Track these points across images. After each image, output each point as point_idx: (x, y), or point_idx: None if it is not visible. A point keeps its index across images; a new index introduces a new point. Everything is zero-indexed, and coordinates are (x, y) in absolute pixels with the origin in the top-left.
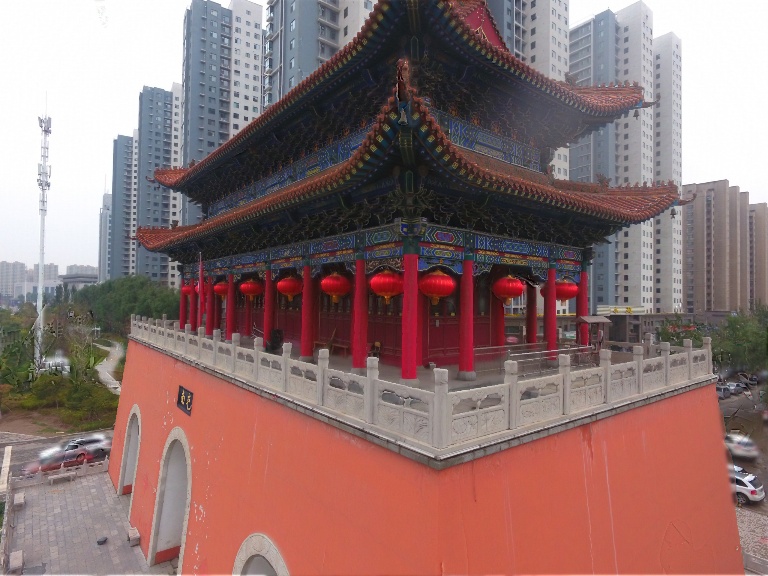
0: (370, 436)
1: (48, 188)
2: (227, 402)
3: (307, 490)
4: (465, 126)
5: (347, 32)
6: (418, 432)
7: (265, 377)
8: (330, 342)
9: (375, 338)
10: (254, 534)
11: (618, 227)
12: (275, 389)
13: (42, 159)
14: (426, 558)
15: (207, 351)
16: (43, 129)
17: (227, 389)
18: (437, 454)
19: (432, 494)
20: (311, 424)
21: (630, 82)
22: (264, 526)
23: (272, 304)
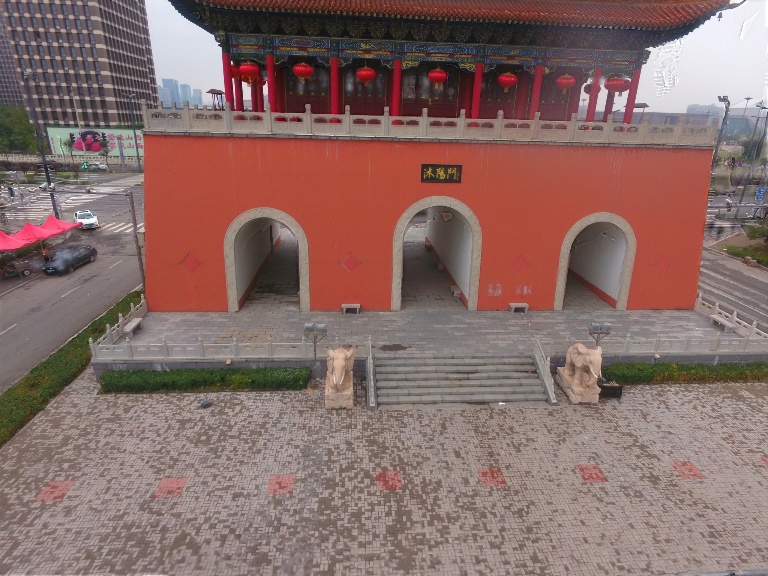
0: None
1: None
2: None
3: None
4: None
5: None
6: None
7: None
8: None
9: None
10: None
11: (197, 7)
12: None
13: None
14: None
15: None
16: None
17: None
18: None
19: None
20: None
21: None
22: None
23: None
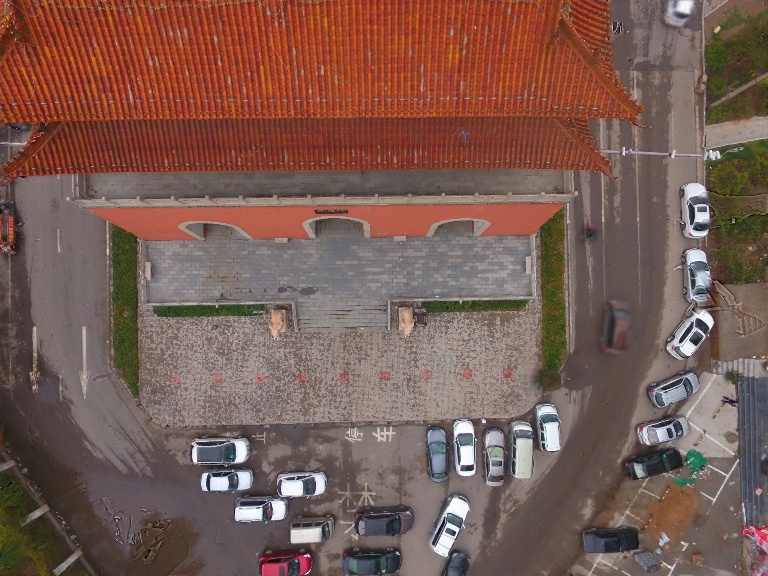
0: None
1: None
2: None
3: None
4: None
5: None
6: None
7: None
8: None
9: None
10: None
11: None
12: None
13: None
14: None
15: None
16: None
17: None
18: None
19: None
20: None
21: None
22: None
23: None
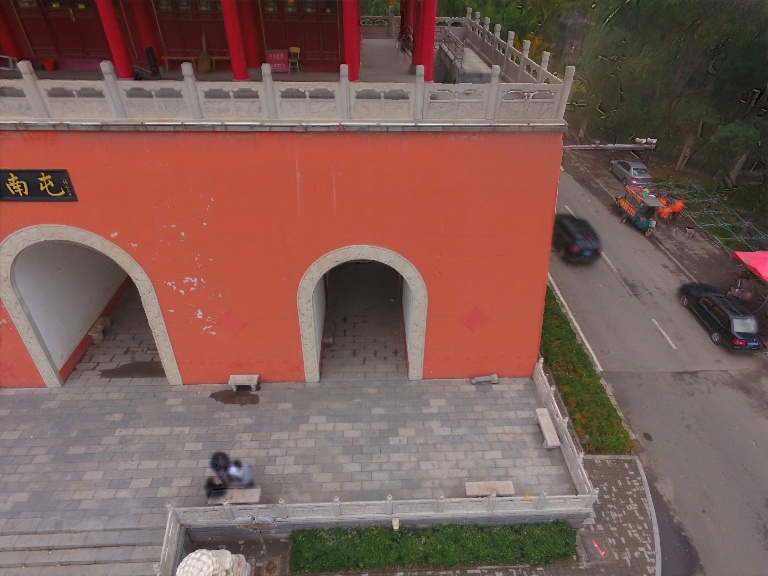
0: (500, 128)
1: None
2: (206, 157)
3: (413, 190)
4: None
5: None
6: (544, 113)
7: (296, 111)
8: (207, 55)
9: (287, 42)
10: (331, 252)
11: None
12: (331, 119)
13: None
14: (548, 183)
15: (79, 100)
16: None
17: (197, 142)
18: (564, 123)
19: (557, 147)
20: (411, 138)
21: None
22: (343, 241)
23: (112, 5)
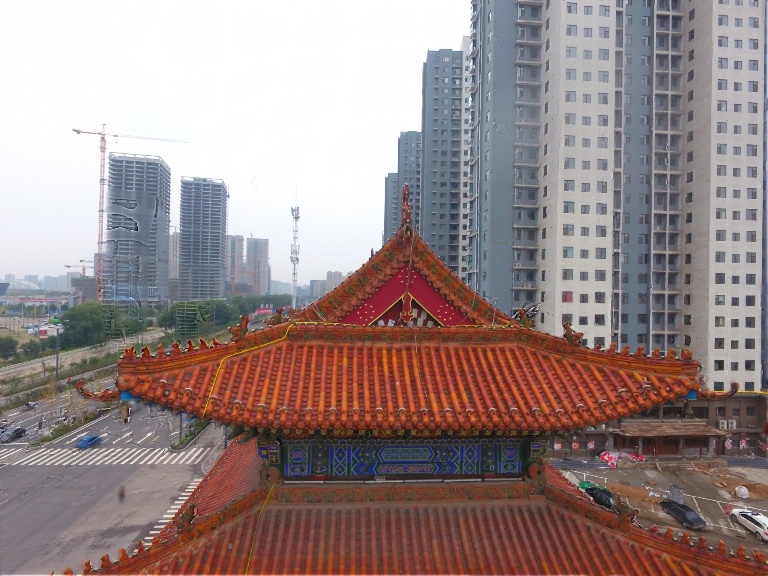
0: None
1: (297, 262)
2: None
3: None
4: (357, 448)
5: (548, 67)
6: None
7: None
8: None
9: None
10: None
11: None
12: None
13: (294, 240)
14: None
15: None
16: (294, 216)
17: None
18: None
19: None
20: None
21: (676, 351)
22: None
23: None
